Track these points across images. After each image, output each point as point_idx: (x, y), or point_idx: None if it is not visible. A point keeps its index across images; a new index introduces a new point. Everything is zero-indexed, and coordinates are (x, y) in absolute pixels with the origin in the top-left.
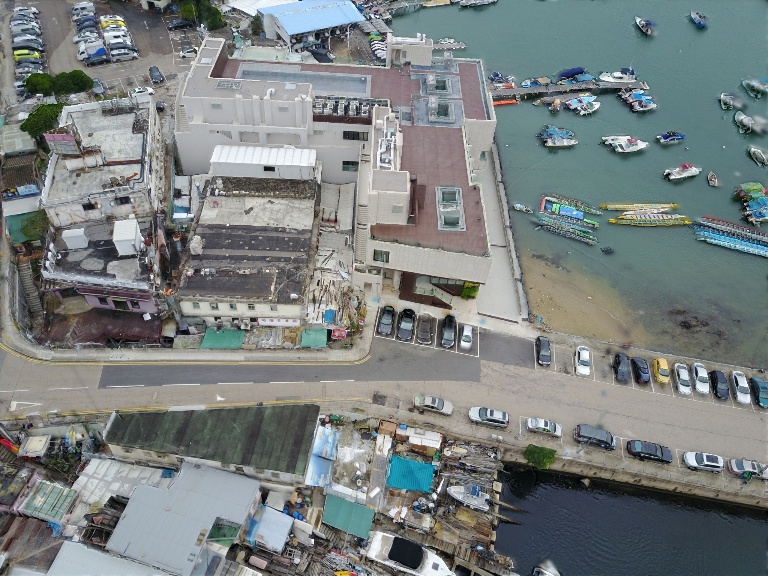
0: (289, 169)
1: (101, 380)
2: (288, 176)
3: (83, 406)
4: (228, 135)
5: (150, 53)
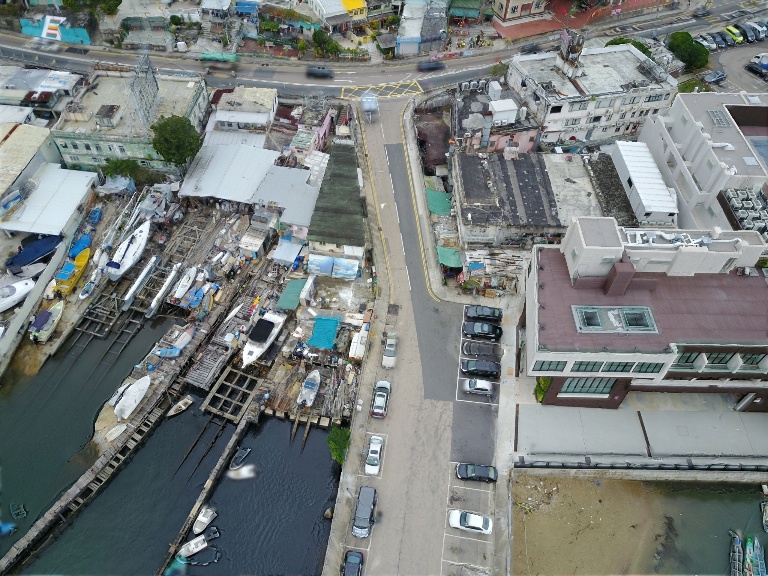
0: (636, 196)
1: (391, 144)
2: (633, 202)
3: (370, 140)
4: (665, 148)
5: None
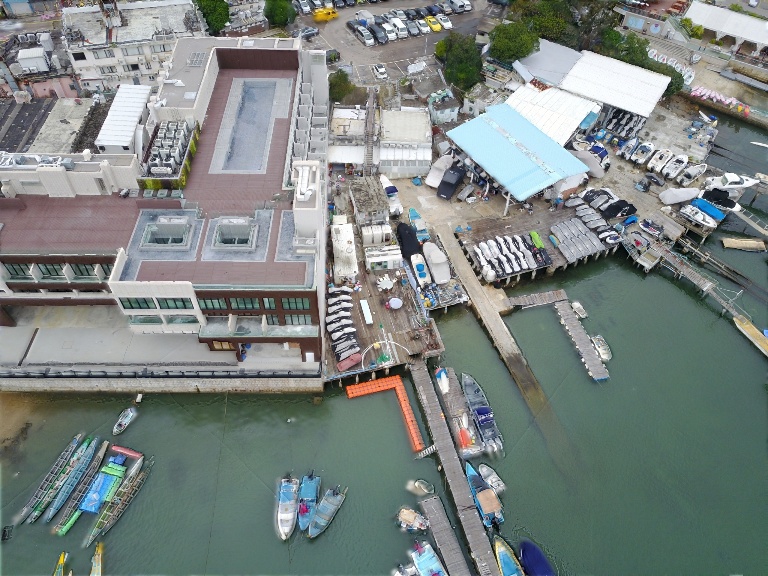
0: None
1: None
2: None
3: None
4: None
5: (380, 51)
